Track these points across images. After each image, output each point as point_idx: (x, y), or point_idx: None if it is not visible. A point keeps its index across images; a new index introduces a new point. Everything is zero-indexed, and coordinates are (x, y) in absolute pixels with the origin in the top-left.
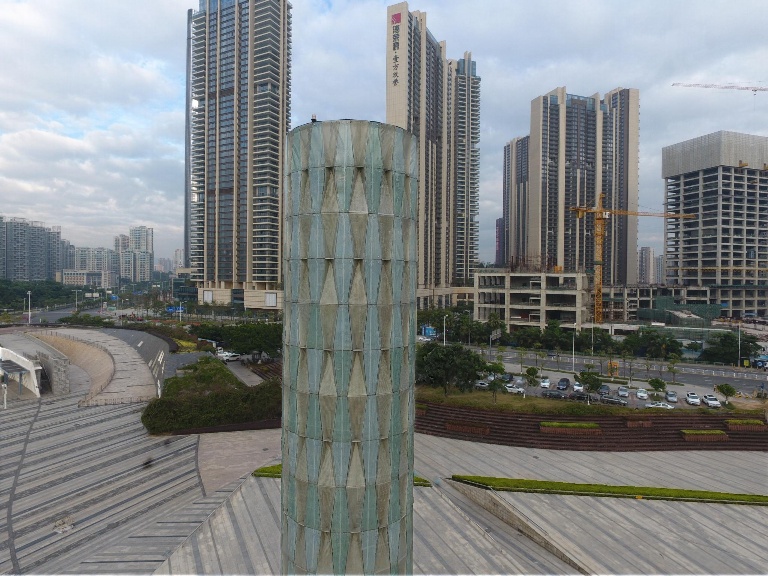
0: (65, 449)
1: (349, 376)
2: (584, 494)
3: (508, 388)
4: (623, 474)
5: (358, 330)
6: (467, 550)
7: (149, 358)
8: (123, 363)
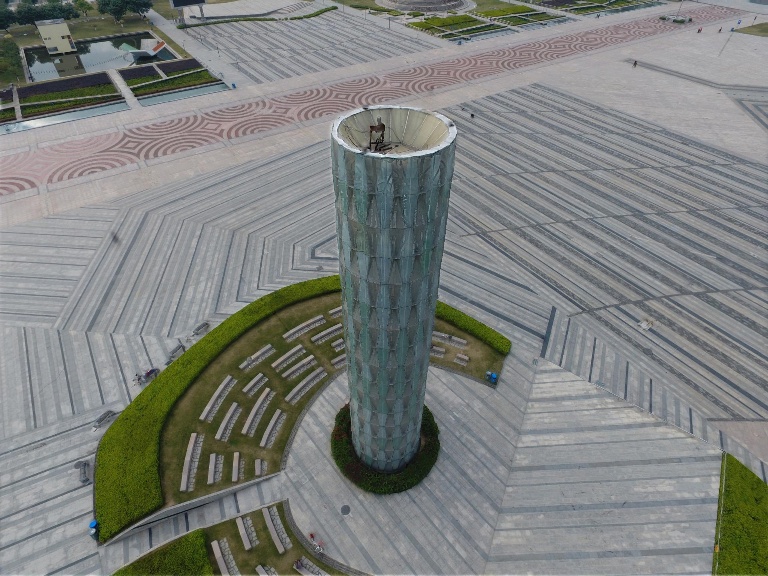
0: None
1: None
2: None
3: None
4: None
5: None
6: None
7: None
8: None
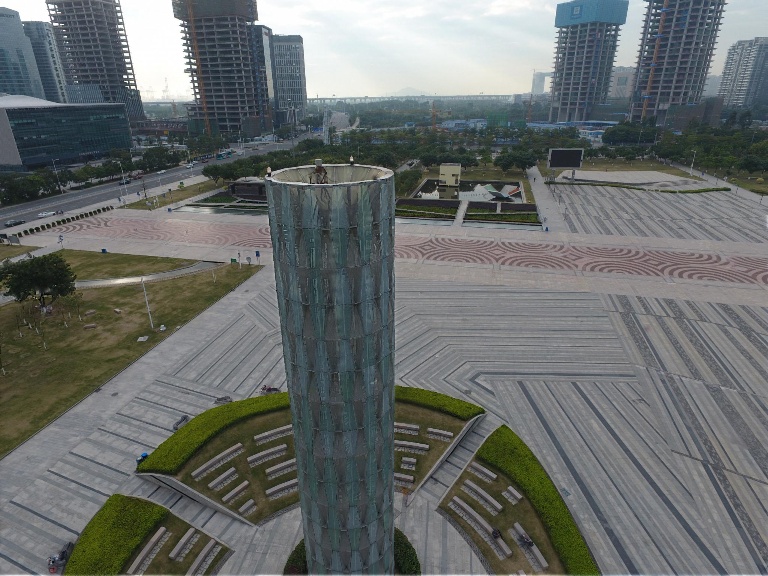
0: None
1: None
2: None
3: None
4: None
5: None
6: None
7: None
8: None
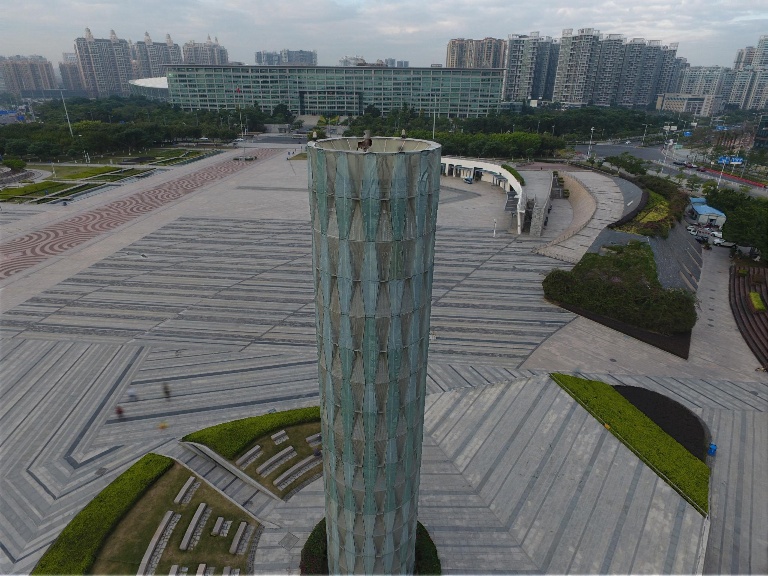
0: (488, 284)
1: (320, 350)
2: None
3: None
4: None
5: None
6: None
7: None
8: (599, 220)
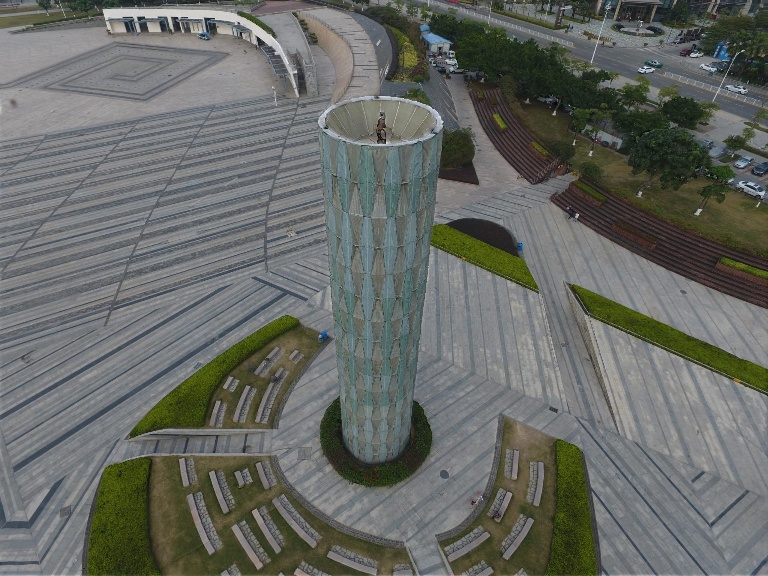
0: (304, 161)
1: (353, 307)
2: (678, 355)
3: (746, 187)
4: (767, 346)
5: (359, 284)
6: (529, 355)
7: (381, 65)
8: (361, 66)
